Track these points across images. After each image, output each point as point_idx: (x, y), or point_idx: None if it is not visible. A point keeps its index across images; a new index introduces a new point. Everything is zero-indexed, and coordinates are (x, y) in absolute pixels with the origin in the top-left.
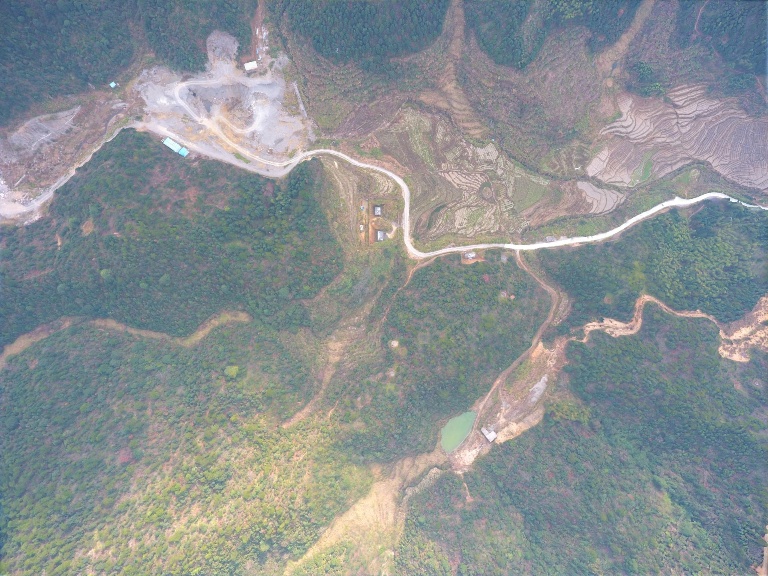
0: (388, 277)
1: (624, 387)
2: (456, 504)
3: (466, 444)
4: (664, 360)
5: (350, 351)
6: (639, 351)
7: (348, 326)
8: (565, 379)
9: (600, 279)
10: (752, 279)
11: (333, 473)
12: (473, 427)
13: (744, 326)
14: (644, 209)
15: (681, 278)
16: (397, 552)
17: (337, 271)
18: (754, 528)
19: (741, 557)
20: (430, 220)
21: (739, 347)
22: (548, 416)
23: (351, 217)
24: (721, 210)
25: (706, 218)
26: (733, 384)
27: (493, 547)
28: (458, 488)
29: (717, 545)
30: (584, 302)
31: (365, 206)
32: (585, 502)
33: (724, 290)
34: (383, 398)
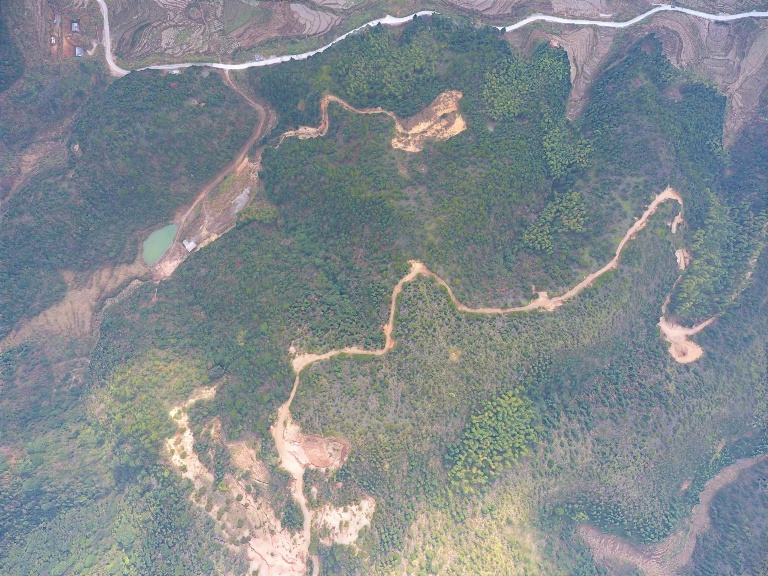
0: (88, 93)
1: (298, 180)
2: (141, 305)
3: (167, 256)
4: (338, 153)
5: (41, 161)
6: (314, 145)
7: (45, 140)
8: (261, 187)
9: (293, 86)
10: (436, 78)
11: (6, 270)
12: (175, 239)
13: (423, 121)
14: (353, 26)
15: (368, 80)
16: (91, 358)
17: (13, 74)
18: (384, 288)
19: (371, 317)
20: (133, 38)
21: (414, 139)
22: (237, 219)
23: (38, 27)
24: (427, 24)
25: (409, 30)
26: (396, 168)
27: (157, 333)
28: (147, 291)
29: (355, 311)
30: (284, 114)
31: (59, 20)
32: (240, 282)
33: (407, 89)
34: (53, 193)
